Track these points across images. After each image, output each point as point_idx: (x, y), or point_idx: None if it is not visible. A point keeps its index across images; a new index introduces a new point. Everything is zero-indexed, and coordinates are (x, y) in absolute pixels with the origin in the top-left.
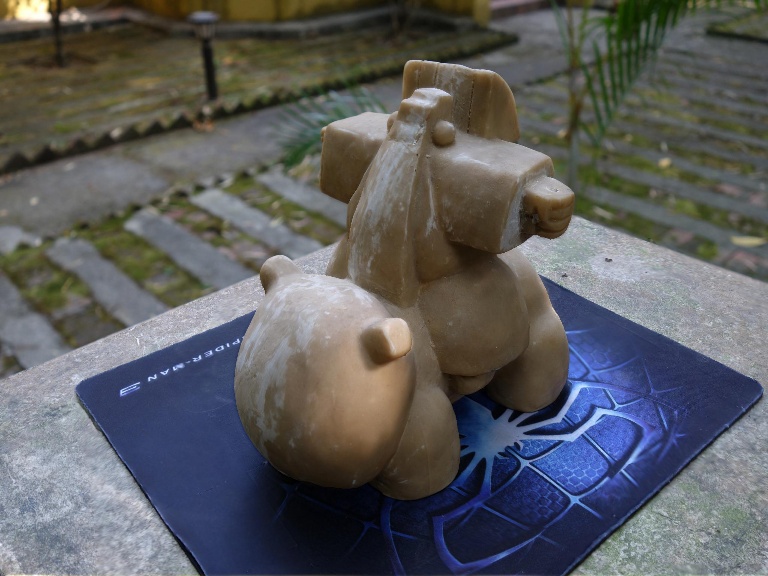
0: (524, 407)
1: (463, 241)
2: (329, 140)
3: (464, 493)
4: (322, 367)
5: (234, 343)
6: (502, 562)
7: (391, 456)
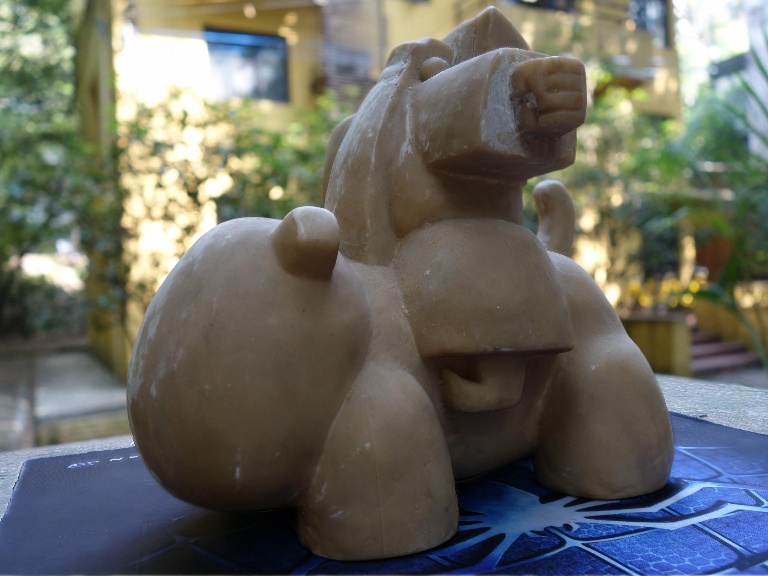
0: (591, 486)
1: (441, 154)
2: (330, 139)
3: (447, 562)
4: (209, 270)
5: None
6: None
7: (312, 452)
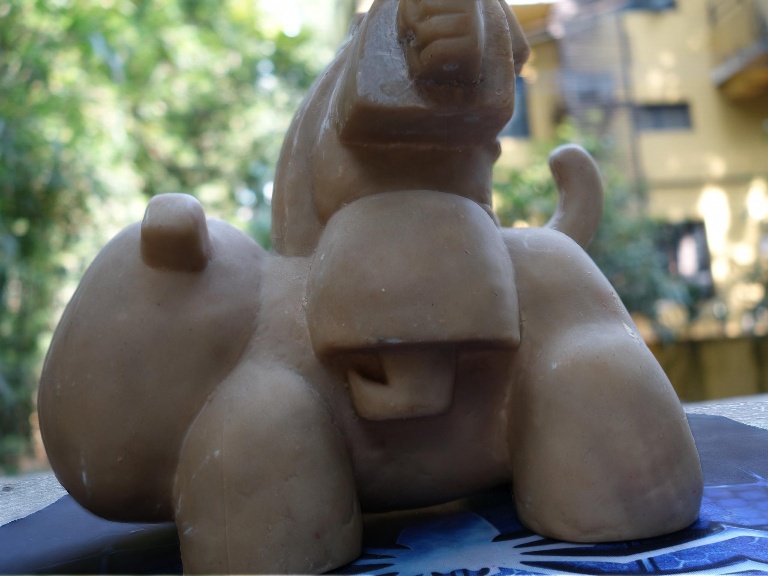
0: (554, 523)
1: (343, 122)
2: None
3: None
4: None
5: None
6: None
7: (166, 459)
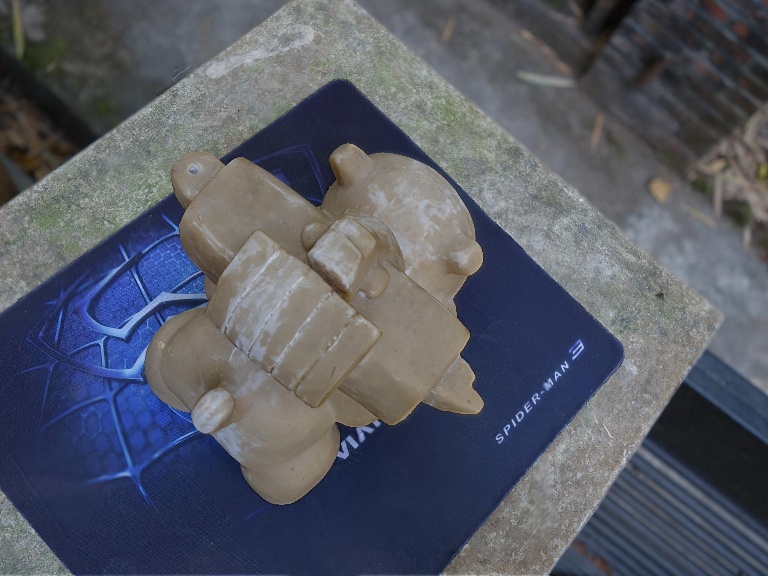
0: None
1: None
2: None
3: None
4: None
5: (509, 426)
6: None
7: None
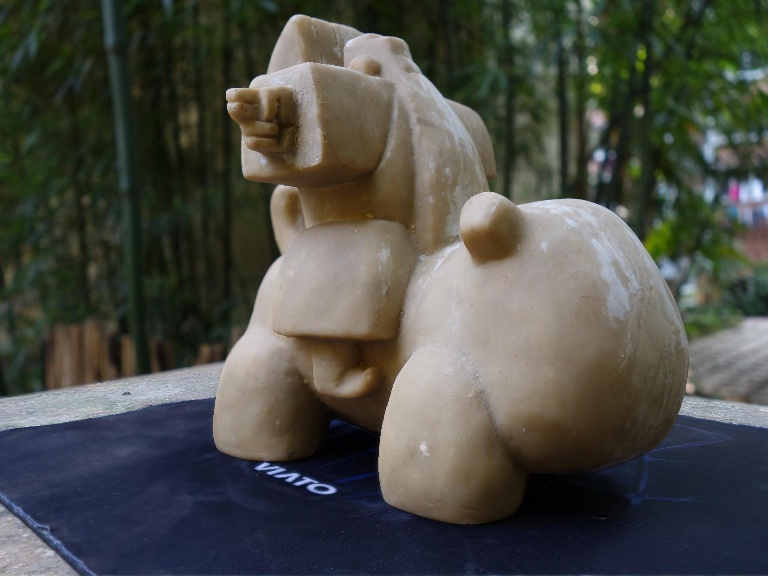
0: None
1: None
2: (329, 81)
3: None
4: None
5: None
6: None
7: None
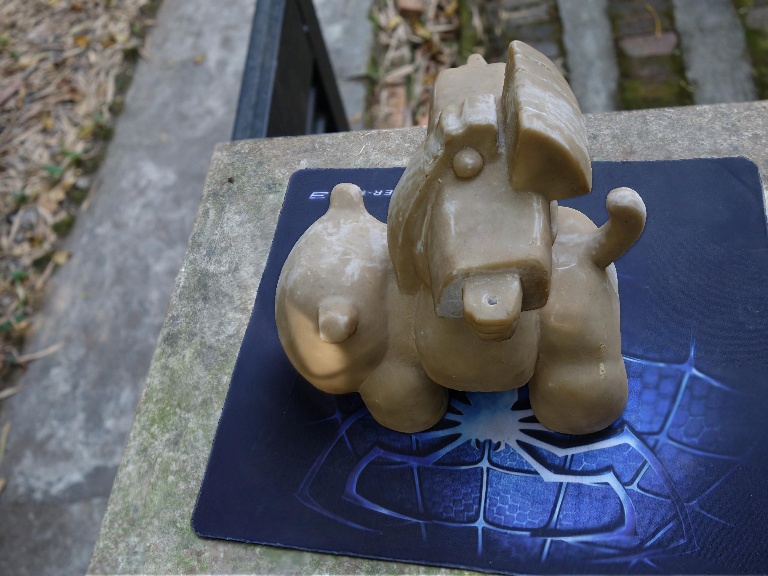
0: None
1: None
2: None
3: (415, 447)
4: (290, 310)
5: None
6: (378, 515)
7: None
